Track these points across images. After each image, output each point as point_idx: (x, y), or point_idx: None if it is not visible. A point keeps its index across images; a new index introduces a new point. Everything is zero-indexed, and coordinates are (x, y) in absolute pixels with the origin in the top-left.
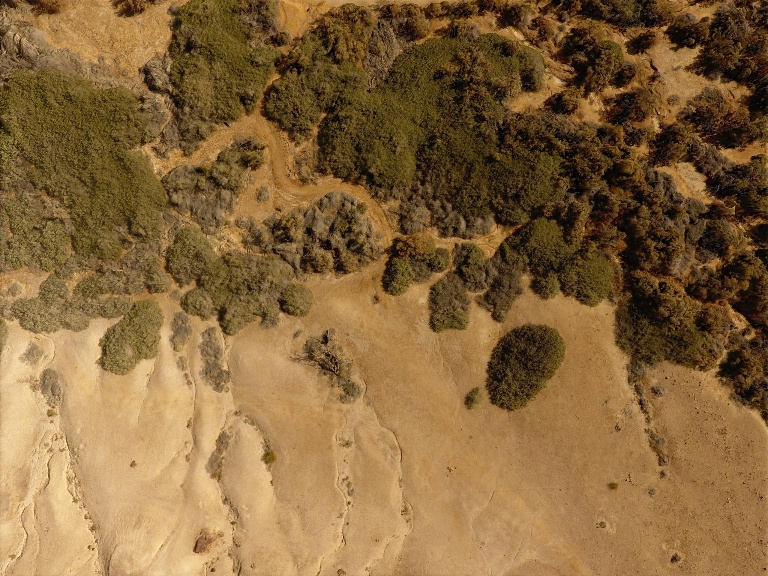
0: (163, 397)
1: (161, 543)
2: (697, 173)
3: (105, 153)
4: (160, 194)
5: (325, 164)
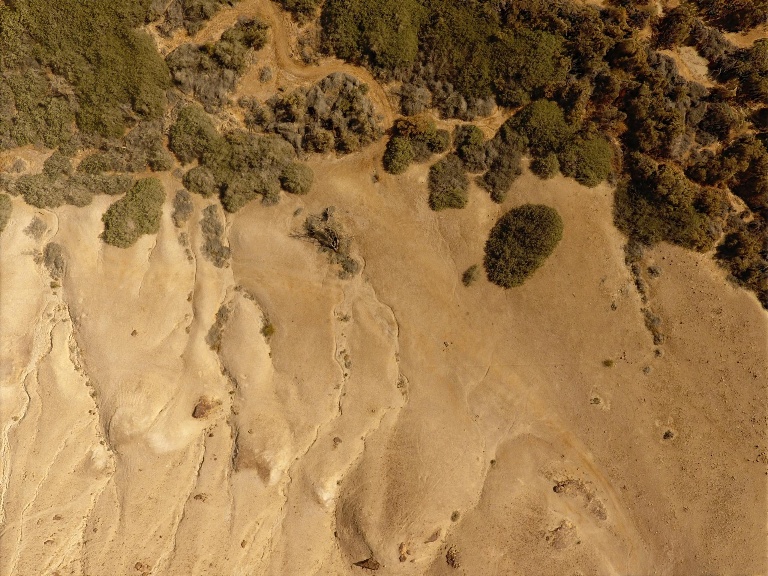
0: (164, 270)
1: (161, 408)
2: (699, 57)
3: (110, 30)
4: (164, 72)
5: (328, 43)
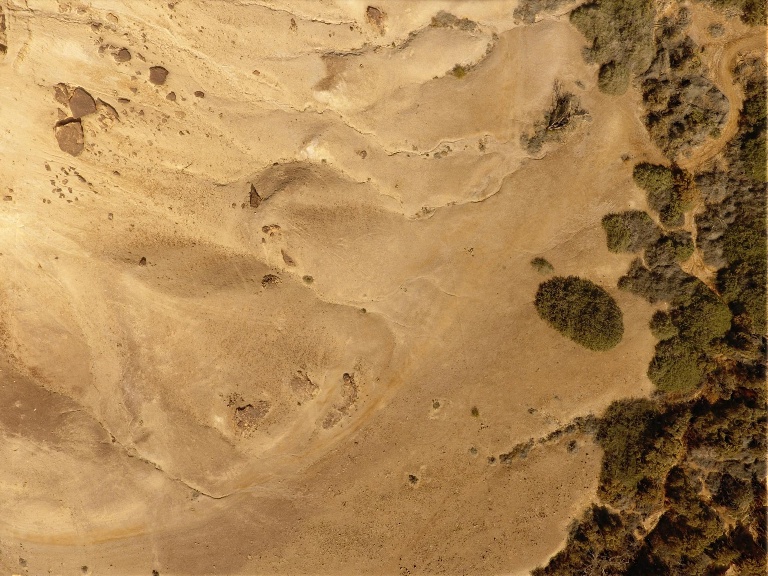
0: None
1: None
2: None
3: None
4: None
5: (760, 89)
